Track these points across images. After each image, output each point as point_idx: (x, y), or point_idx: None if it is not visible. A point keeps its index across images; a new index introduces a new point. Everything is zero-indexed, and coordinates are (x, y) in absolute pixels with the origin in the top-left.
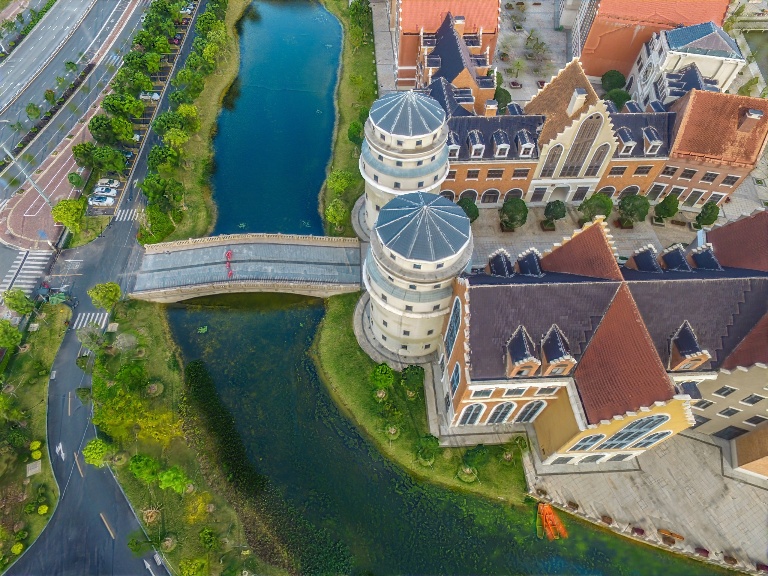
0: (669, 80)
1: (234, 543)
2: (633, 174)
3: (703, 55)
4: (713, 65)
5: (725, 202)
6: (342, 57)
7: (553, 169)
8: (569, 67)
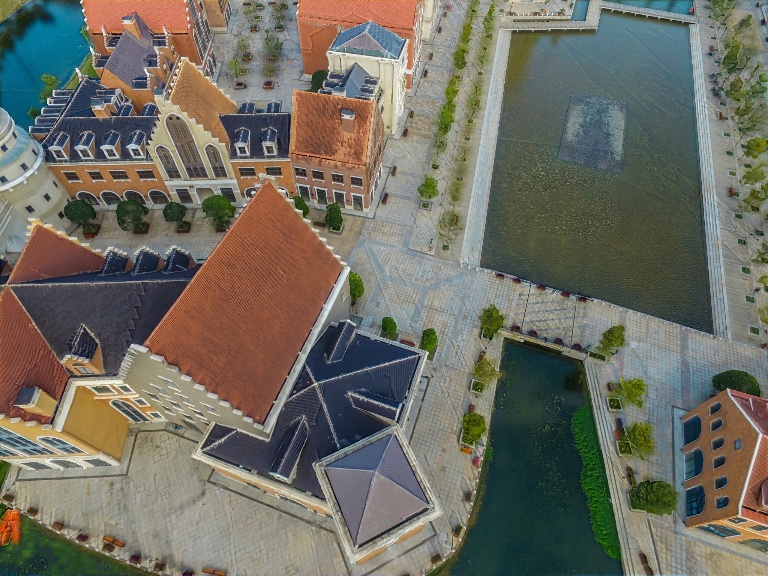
0: (330, 80)
1: None
2: None
3: (360, 55)
4: (374, 65)
5: (382, 203)
6: (87, 58)
7: (177, 170)
8: (180, 67)
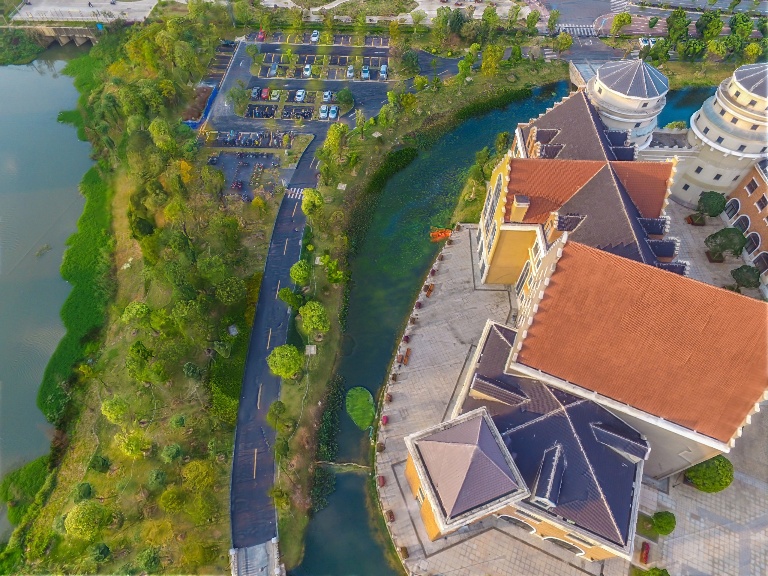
0: None
1: (434, 108)
2: None
3: None
4: None
5: None
6: None
7: None
8: None
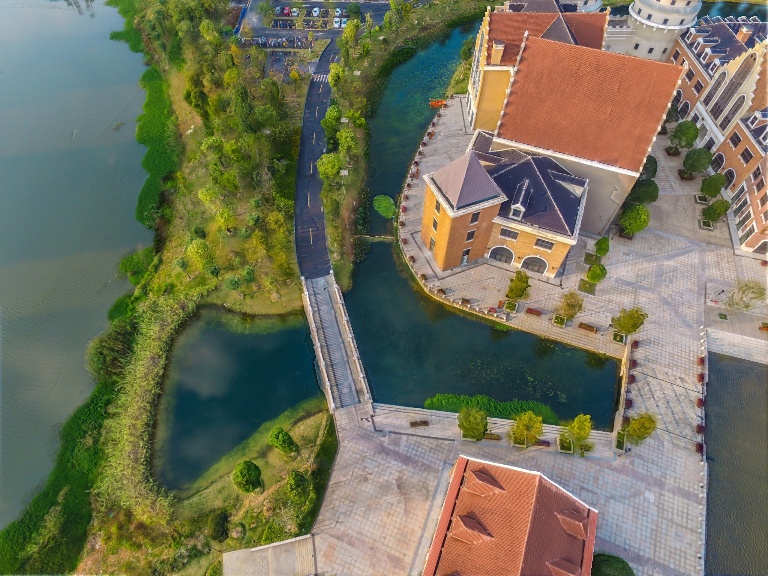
0: None
1: (427, 20)
2: (740, 155)
3: None
4: None
5: None
6: None
7: None
8: None
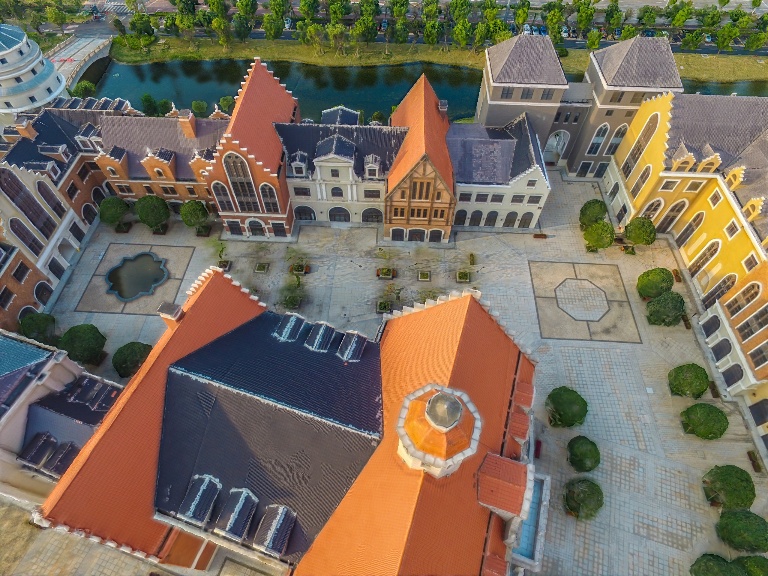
0: None
1: None
2: None
3: None
4: None
5: None
6: None
7: None
8: None
